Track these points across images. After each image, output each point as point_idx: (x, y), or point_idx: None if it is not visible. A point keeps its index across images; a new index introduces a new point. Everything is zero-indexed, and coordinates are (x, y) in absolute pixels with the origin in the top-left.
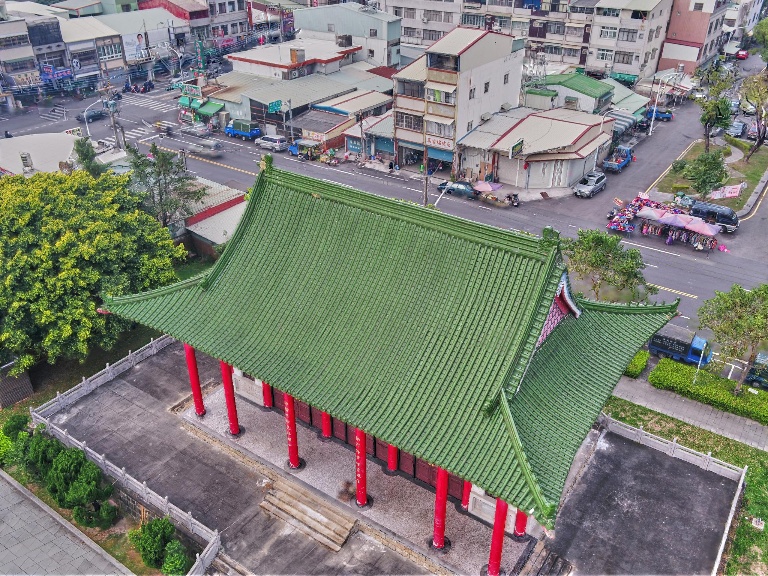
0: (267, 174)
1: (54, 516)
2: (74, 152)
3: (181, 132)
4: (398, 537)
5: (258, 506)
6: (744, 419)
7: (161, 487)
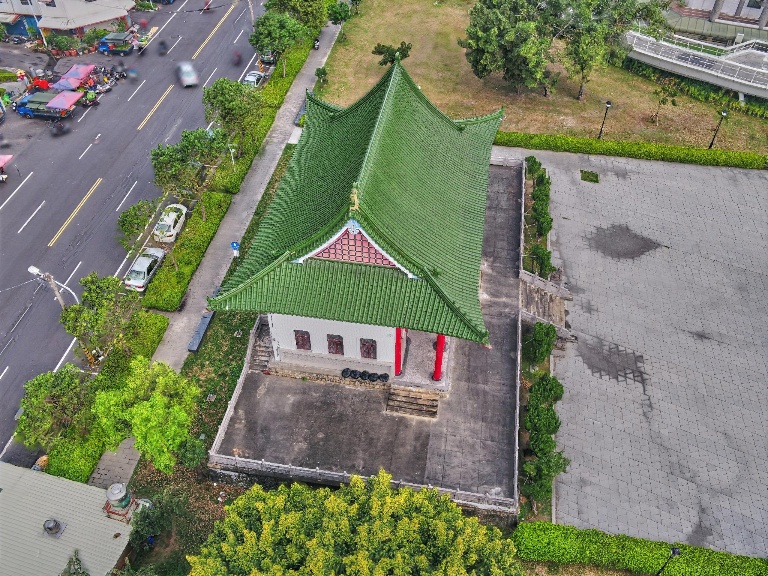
0: None
1: None
2: None
3: None
4: None
5: None
6: (255, 159)
7: (503, 373)
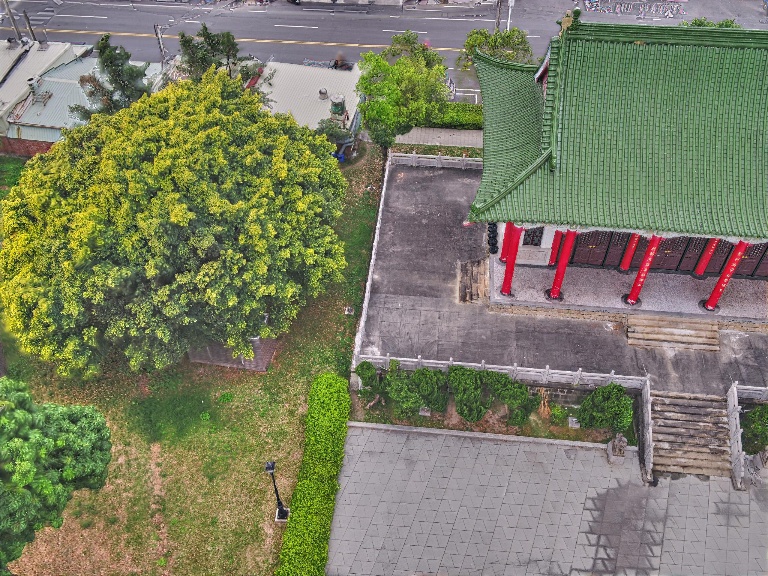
0: (572, 31)
1: (455, 434)
2: (102, 59)
3: (131, 3)
4: (760, 320)
5: (629, 345)
6: None
7: (540, 366)
